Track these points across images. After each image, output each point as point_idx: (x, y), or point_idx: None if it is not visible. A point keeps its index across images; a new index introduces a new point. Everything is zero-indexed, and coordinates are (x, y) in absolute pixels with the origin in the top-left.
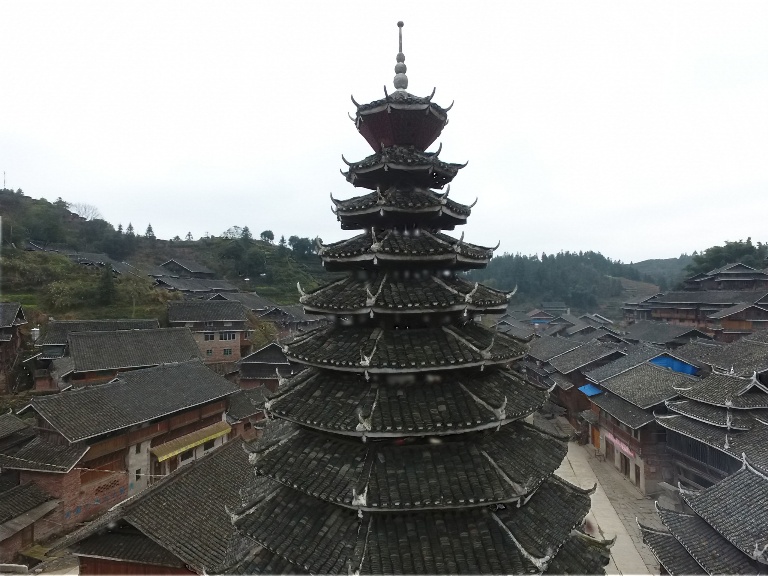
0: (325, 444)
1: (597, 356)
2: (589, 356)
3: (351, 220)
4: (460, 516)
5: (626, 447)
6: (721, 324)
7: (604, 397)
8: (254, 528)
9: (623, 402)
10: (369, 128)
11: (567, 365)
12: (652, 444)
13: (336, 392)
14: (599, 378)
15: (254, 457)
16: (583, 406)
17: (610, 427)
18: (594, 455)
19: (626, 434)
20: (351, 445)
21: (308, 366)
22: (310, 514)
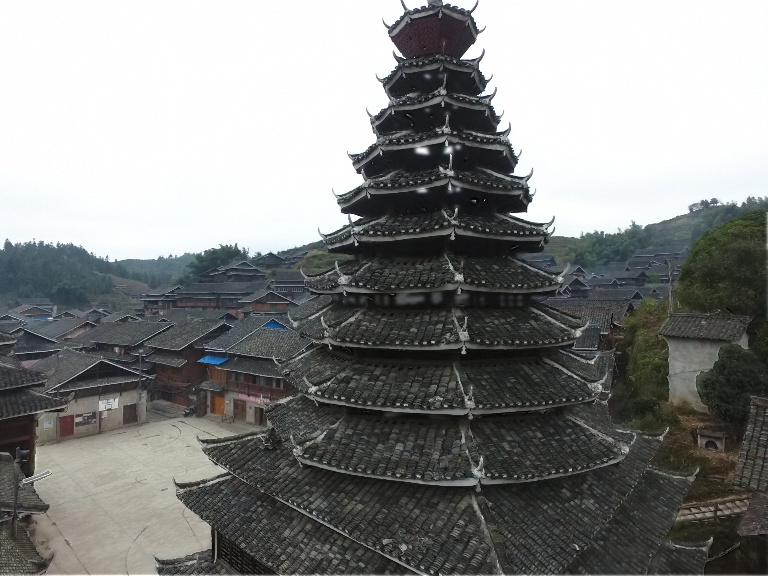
0: (494, 313)
1: (207, 330)
2: (196, 331)
3: (446, 110)
4: (552, 352)
5: (264, 399)
6: (251, 306)
7: (234, 362)
8: (494, 400)
9: (257, 362)
10: (440, 28)
11: (175, 342)
12: (291, 389)
13: (491, 266)
14: (226, 346)
15: (467, 332)
16: (193, 381)
17: (244, 387)
18: (221, 420)
19: (266, 388)
20: (509, 311)
21: (368, 261)
22: (510, 374)
